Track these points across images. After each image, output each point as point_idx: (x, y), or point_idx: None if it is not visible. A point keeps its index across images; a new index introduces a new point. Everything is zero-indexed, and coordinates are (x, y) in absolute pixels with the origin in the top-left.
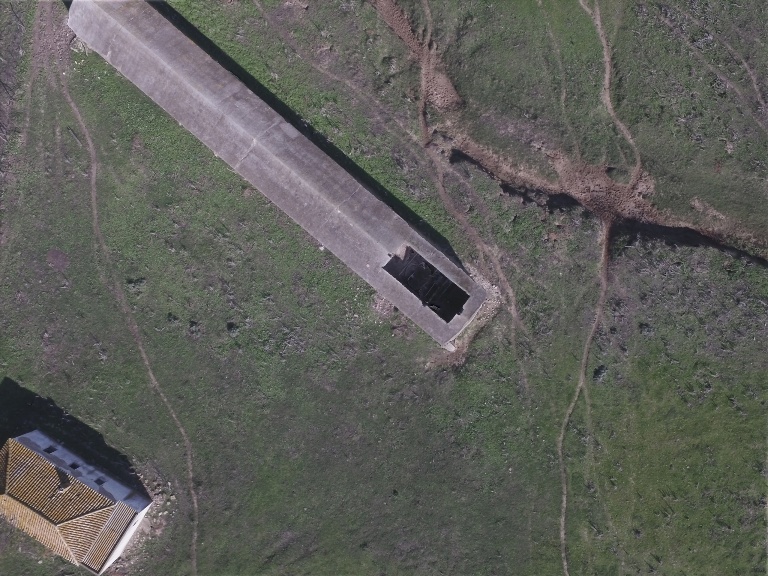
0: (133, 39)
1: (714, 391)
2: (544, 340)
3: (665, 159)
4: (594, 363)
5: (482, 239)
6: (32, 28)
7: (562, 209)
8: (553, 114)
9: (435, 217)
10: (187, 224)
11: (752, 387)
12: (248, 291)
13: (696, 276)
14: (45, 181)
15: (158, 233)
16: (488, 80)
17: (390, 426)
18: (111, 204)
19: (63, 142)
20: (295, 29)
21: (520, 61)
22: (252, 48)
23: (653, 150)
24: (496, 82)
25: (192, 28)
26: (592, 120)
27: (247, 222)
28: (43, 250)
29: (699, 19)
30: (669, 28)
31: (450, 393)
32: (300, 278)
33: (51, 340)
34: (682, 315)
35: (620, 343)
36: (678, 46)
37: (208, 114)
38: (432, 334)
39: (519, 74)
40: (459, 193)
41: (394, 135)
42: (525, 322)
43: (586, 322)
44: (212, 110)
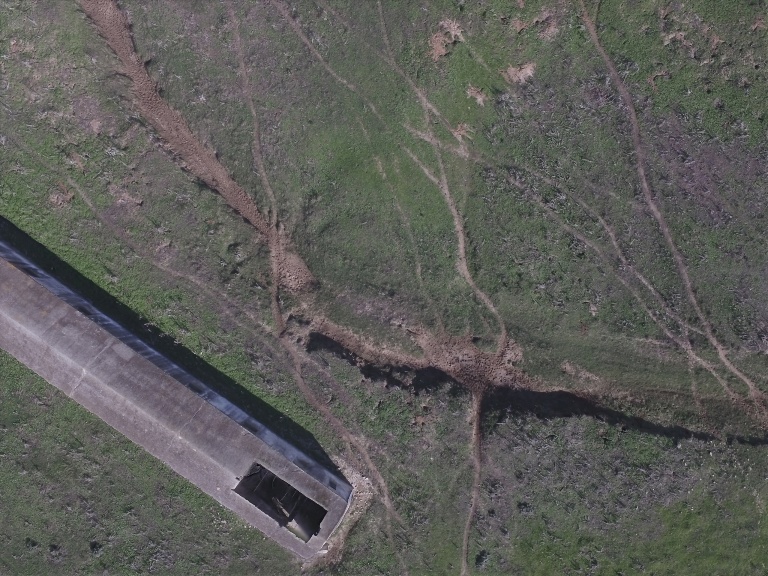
0: None
1: (601, 566)
2: (421, 529)
3: (530, 325)
4: (475, 549)
5: (347, 429)
6: None
7: (428, 389)
8: (411, 288)
9: (296, 411)
10: (37, 442)
11: (639, 559)
12: (108, 506)
13: (571, 448)
14: None
15: (8, 454)
16: (339, 260)
17: None
18: None
19: None
20: (131, 227)
21: (370, 238)
22: (88, 251)
23: (517, 317)
24: (347, 262)
25: (23, 235)
26: (451, 292)
27: (100, 434)
28: None
29: (550, 178)
30: (520, 191)
31: None
32: (162, 488)
33: None
34: (561, 490)
35: (500, 525)
36: (531, 209)
37: (33, 345)
38: (294, 551)
39: (370, 251)
40: (319, 383)
41: (245, 329)
42: (400, 512)
43: (463, 507)
44: (36, 341)
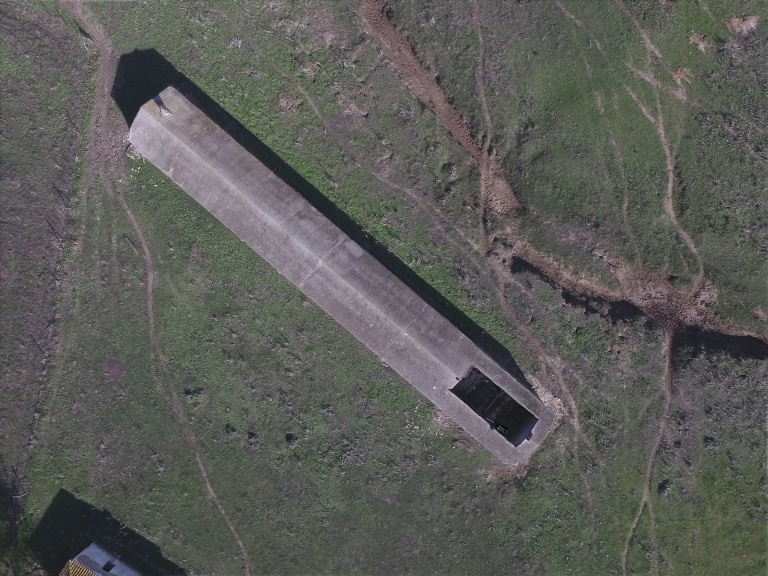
0: (197, 158)
1: None
2: (607, 453)
3: (729, 268)
4: (658, 477)
5: (544, 350)
6: (88, 134)
7: (625, 320)
8: (615, 222)
9: (496, 328)
10: (245, 333)
11: None
12: (307, 402)
13: (762, 389)
14: (101, 289)
15: (216, 342)
16: (549, 188)
17: (451, 539)
18: (168, 313)
19: (119, 250)
20: (354, 137)
21: (582, 169)
22: (311, 156)
23: (716, 259)
24: (558, 190)
25: (250, 135)
26: (655, 229)
27: (306, 332)
28: (99, 359)
29: (763, 128)
30: (733, 137)
31: (512, 507)
32: (360, 389)
33: (107, 451)
34: (747, 429)
35: (685, 457)
36: (742, 155)
37: (272, 234)
38: (499, 456)
39: (581, 182)
40: (521, 303)
41: (455, 244)
42: (588, 435)
43: (650, 436)
44: (277, 230)
